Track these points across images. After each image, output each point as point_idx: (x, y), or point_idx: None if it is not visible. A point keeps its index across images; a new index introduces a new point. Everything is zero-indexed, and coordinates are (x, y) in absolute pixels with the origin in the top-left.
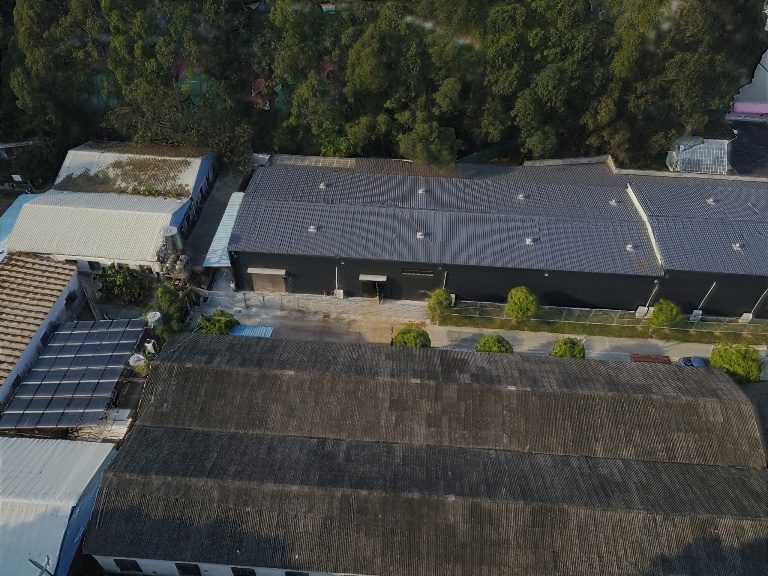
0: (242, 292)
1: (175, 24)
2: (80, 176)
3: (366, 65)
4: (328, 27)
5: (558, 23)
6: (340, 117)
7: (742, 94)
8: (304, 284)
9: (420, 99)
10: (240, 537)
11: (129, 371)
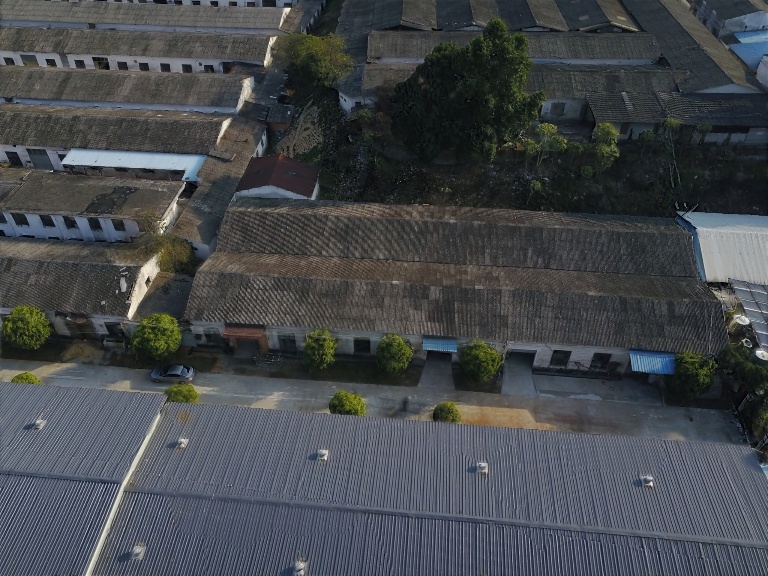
0: None
1: None
2: None
3: None
4: None
5: None
6: None
7: None
8: None
9: None
10: None
11: None
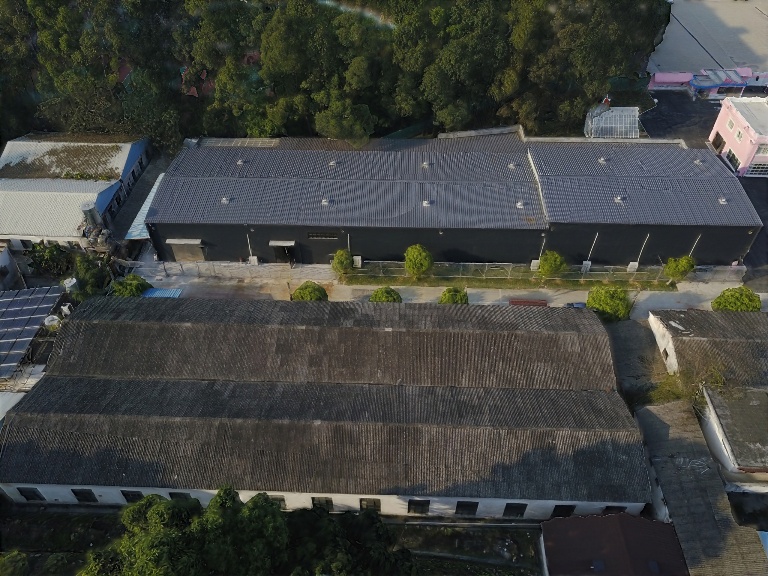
0: (161, 261)
1: (96, 17)
2: (18, 164)
3: (275, 48)
4: (241, 14)
5: (457, 1)
6: (263, 100)
7: (670, 66)
8: (221, 253)
9: (333, 78)
10: (126, 462)
11: (45, 330)
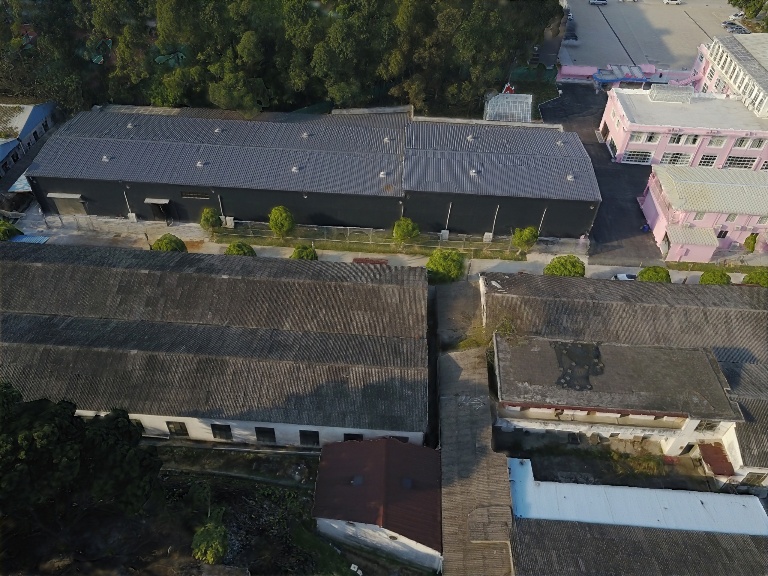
0: (40, 213)
1: None
2: None
3: (166, 18)
4: None
5: None
6: (166, 70)
7: (585, 61)
8: (102, 209)
9: (228, 51)
10: None
11: None
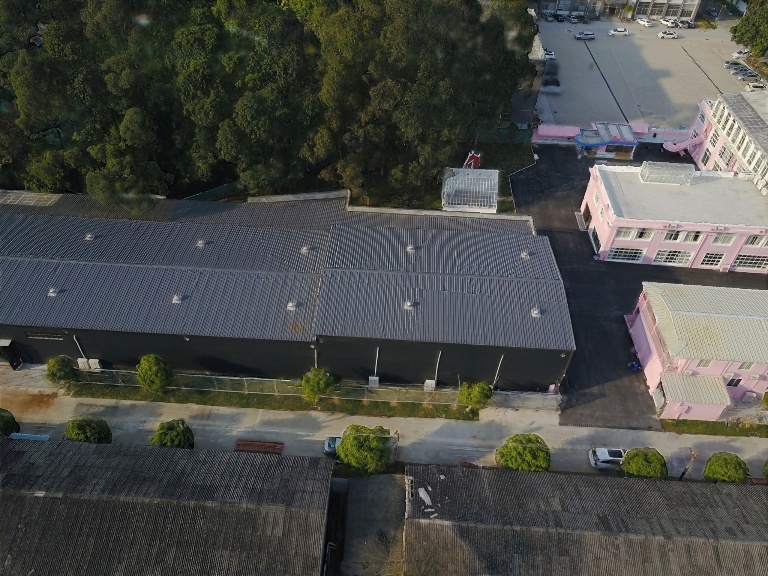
0: None
1: None
2: None
3: None
4: None
5: (256, 46)
6: (42, 149)
7: (567, 113)
8: None
9: (111, 130)
10: None
11: None
